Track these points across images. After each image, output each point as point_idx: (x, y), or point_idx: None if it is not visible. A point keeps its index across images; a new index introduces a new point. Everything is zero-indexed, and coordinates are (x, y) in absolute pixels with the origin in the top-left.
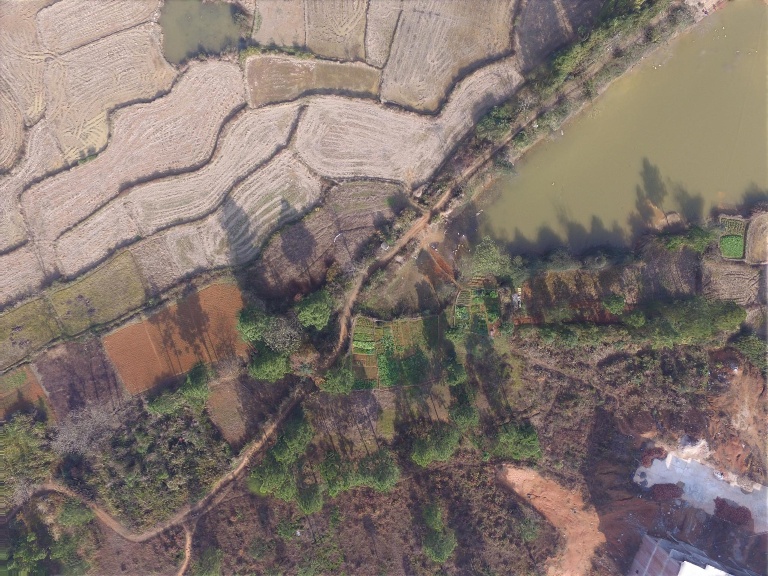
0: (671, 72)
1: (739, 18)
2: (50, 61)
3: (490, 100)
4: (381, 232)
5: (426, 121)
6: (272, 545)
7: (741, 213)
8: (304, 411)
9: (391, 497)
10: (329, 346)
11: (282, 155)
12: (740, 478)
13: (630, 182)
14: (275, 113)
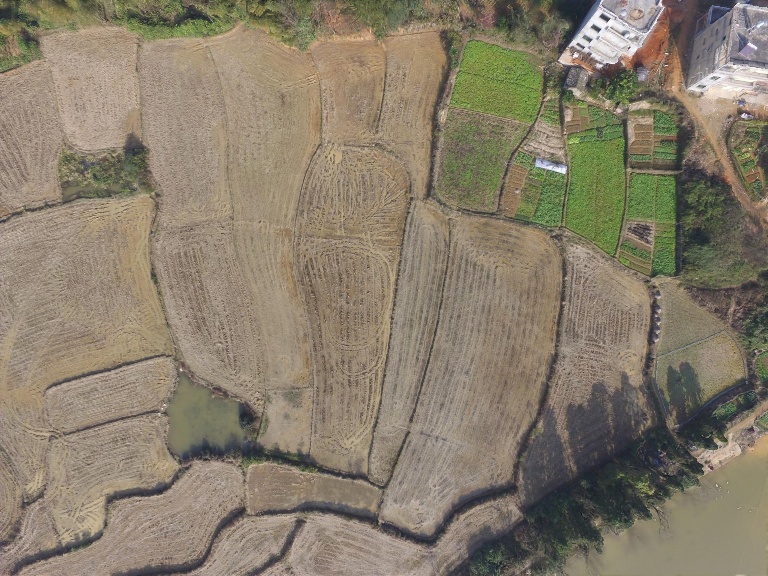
0: None
1: (744, 472)
2: (54, 440)
3: (487, 533)
4: None
5: (421, 548)
6: None
7: None
8: None
9: None
10: None
11: (275, 567)
12: None
13: None
14: (272, 522)
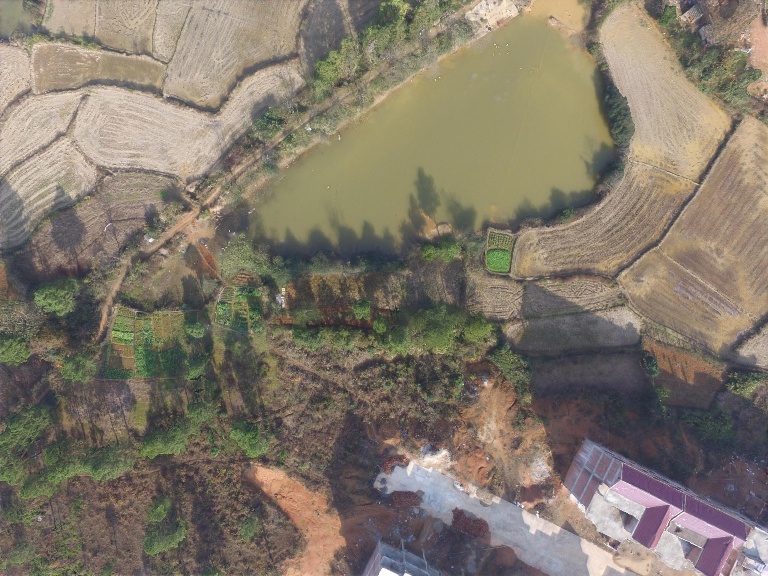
0: (450, 85)
1: (524, 36)
2: None
3: (271, 101)
4: (147, 224)
5: (205, 118)
6: (11, 529)
7: (511, 228)
8: (57, 397)
9: (136, 488)
10: (88, 334)
11: (60, 142)
12: (480, 490)
13: (404, 190)
14: (58, 100)
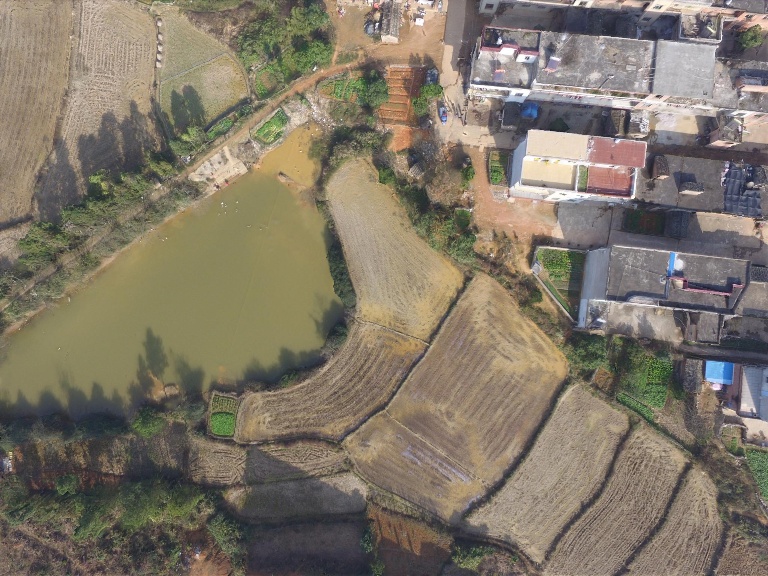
0: (176, 245)
1: (256, 192)
2: None
3: (5, 263)
4: None
5: None
6: None
7: (238, 389)
8: None
9: None
10: None
11: None
12: None
13: (134, 351)
14: None
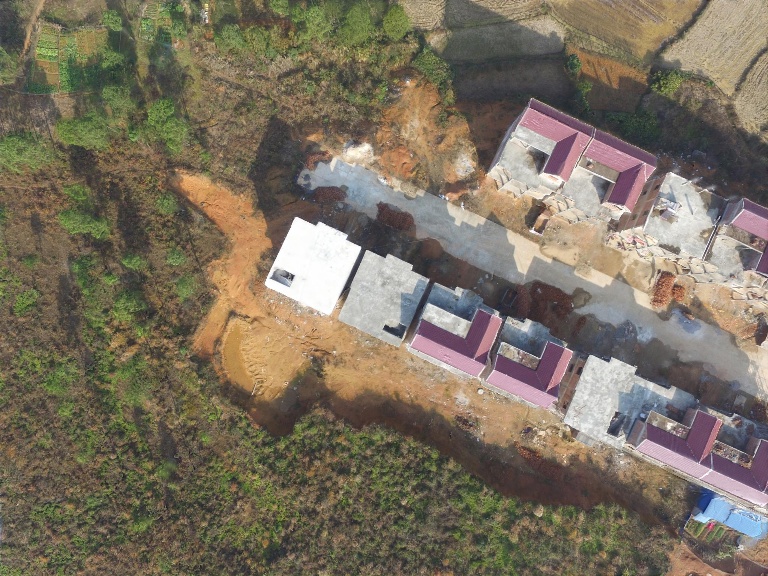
0: None
1: None
2: None
3: None
4: None
5: None
6: None
7: None
8: None
9: (61, 198)
10: (12, 51)
11: None
12: (404, 184)
13: None
14: None
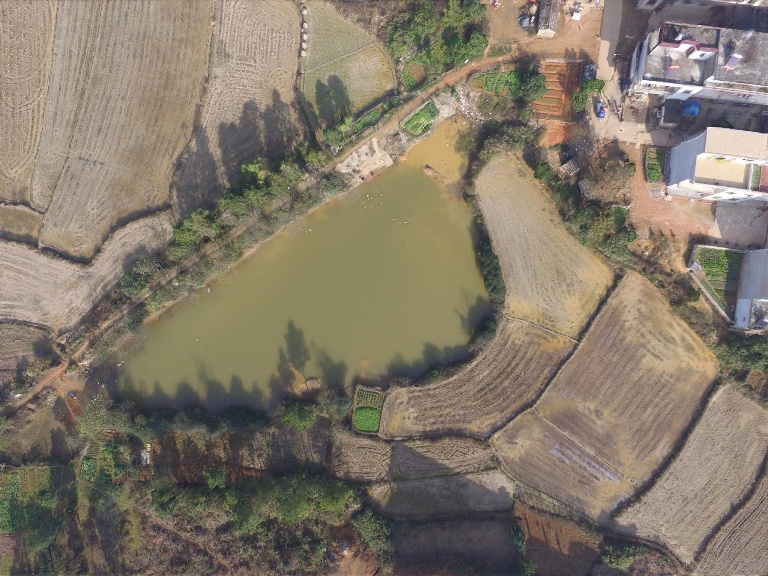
0: (320, 237)
1: (400, 185)
2: None
3: (142, 252)
4: (15, 379)
5: (78, 269)
6: None
7: (382, 384)
8: None
9: None
10: None
11: None
12: None
13: (274, 344)
14: None
